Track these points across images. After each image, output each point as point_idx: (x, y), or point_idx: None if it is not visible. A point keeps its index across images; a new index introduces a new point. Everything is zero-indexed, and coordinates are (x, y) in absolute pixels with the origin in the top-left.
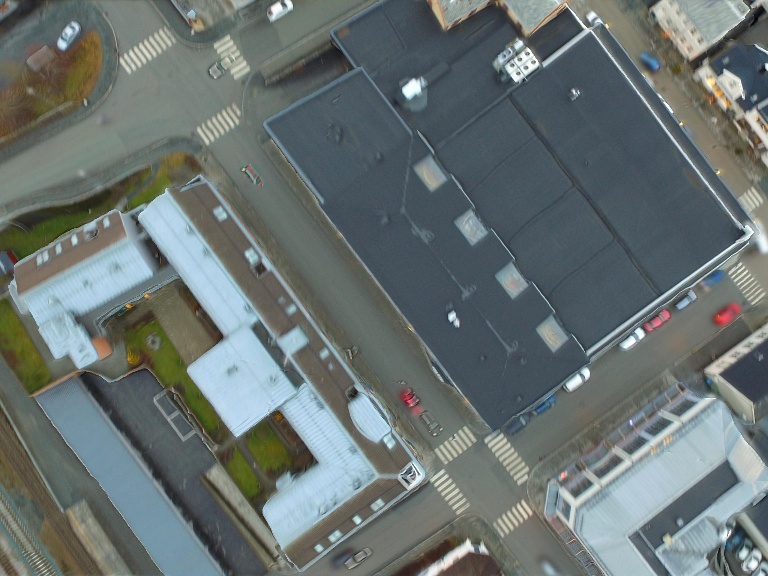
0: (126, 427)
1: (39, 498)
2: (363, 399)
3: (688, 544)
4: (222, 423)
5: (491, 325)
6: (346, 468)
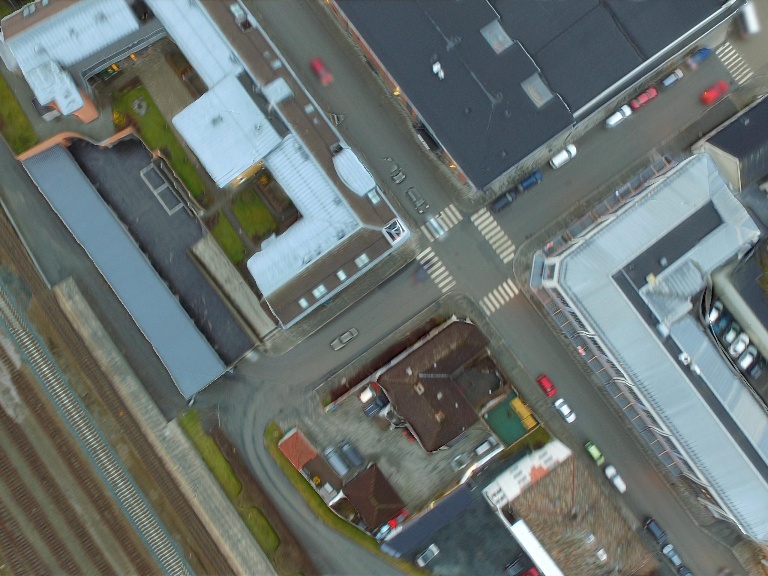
0: (113, 203)
1: (27, 275)
2: (348, 153)
3: (672, 287)
4: (208, 188)
5: (476, 76)
6: (330, 220)
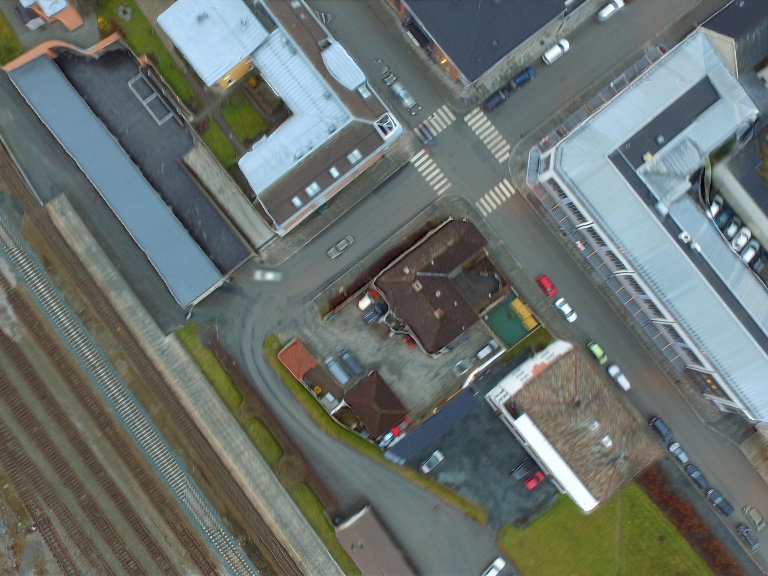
0: (102, 116)
1: (18, 193)
2: (336, 46)
3: (670, 166)
4: (197, 93)
5: None
6: (321, 116)
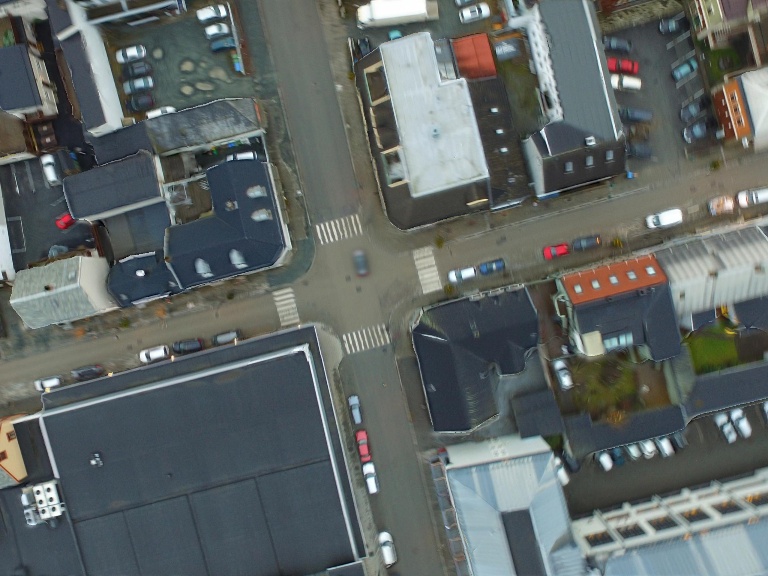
0: None
1: None
2: None
3: None
4: None
5: None
6: None
